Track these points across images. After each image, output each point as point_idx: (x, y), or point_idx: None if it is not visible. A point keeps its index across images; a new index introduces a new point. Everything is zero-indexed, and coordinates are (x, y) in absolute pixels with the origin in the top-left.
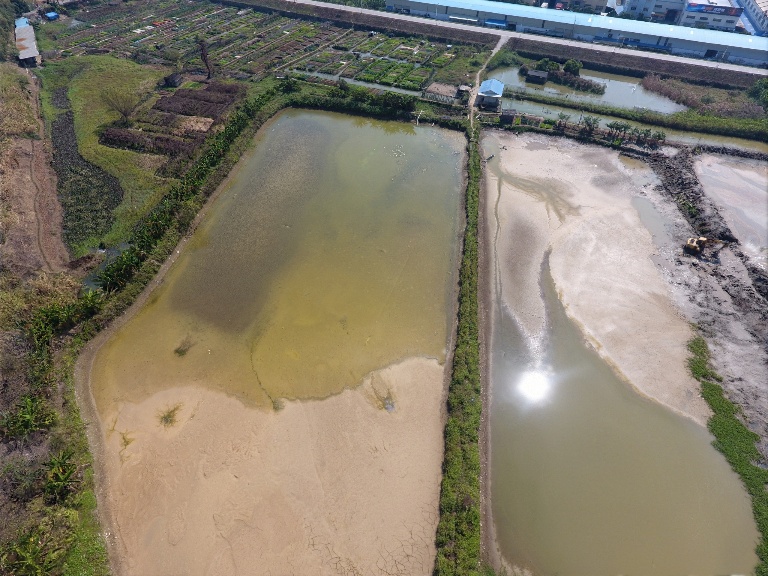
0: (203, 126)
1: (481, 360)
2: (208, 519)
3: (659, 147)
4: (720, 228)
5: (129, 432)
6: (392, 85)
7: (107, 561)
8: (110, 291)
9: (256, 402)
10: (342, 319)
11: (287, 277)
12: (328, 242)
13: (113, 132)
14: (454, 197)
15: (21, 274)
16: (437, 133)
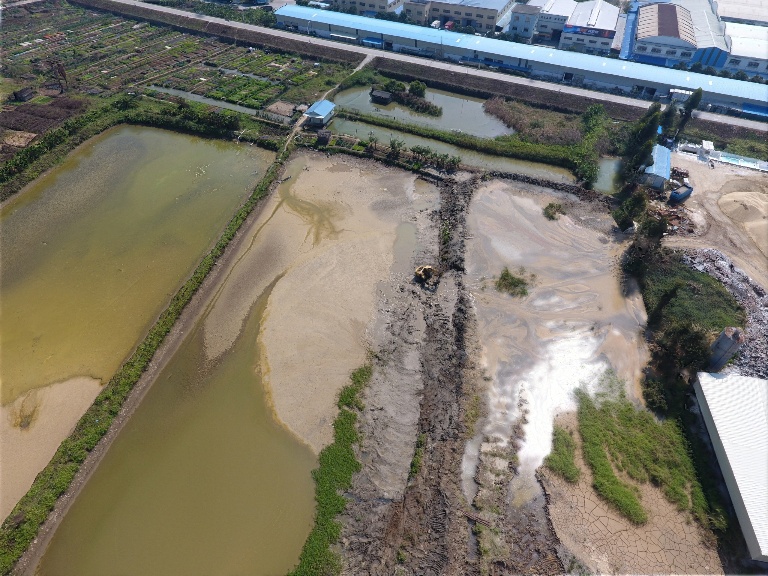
0: (23, 142)
1: (142, 381)
2: None
3: (455, 172)
4: (454, 256)
5: None
6: (237, 103)
7: None
8: None
9: None
10: (37, 337)
11: (12, 294)
12: (74, 260)
13: None
14: (225, 218)
15: None
16: (250, 153)
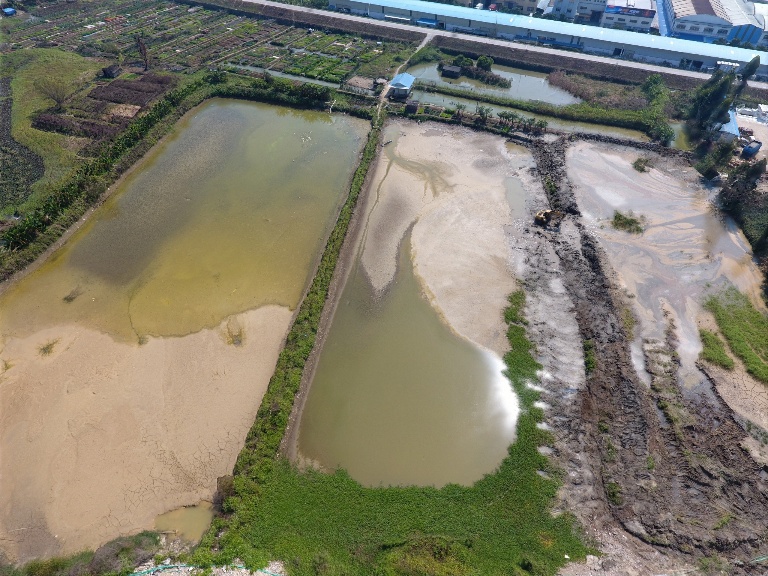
0: (130, 113)
1: (327, 307)
2: (63, 423)
3: (542, 134)
4: (568, 203)
5: (11, 360)
6: (316, 78)
7: None
8: (13, 249)
9: (125, 338)
10: (216, 275)
11: (177, 241)
12: (221, 213)
13: (44, 117)
14: (345, 176)
15: None
16: (346, 121)
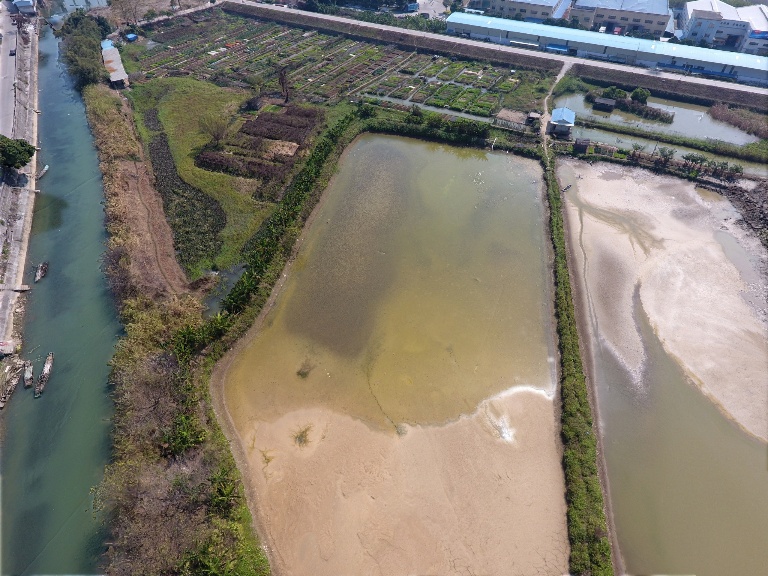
0: (289, 150)
1: (588, 393)
2: (353, 537)
3: (736, 180)
4: None
5: (268, 450)
6: (462, 111)
7: (270, 572)
8: (233, 313)
9: (380, 426)
10: (448, 347)
11: (390, 304)
12: (423, 270)
13: (208, 156)
14: (538, 227)
15: (151, 295)
16: (512, 161)
